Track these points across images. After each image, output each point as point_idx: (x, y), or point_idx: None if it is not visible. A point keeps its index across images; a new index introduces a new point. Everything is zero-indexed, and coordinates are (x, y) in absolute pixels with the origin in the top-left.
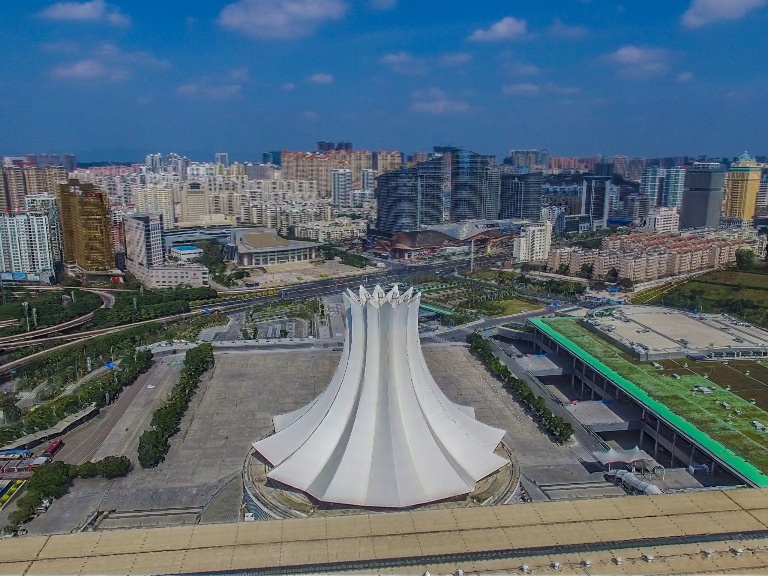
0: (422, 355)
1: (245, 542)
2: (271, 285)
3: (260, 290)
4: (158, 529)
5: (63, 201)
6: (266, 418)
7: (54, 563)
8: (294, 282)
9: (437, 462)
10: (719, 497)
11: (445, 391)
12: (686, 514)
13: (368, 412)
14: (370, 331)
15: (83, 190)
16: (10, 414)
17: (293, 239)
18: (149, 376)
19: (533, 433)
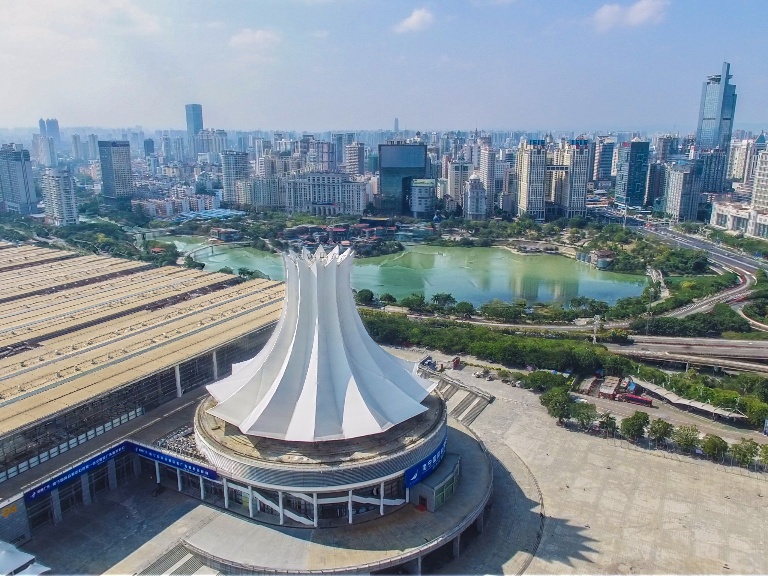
0: (298, 320)
1: None
2: None
3: None
4: None
5: None
6: (663, 505)
7: None
8: None
9: None
10: (8, 427)
11: None
12: (37, 406)
13: None
14: None
15: None
16: (754, 395)
17: None
18: None
19: None
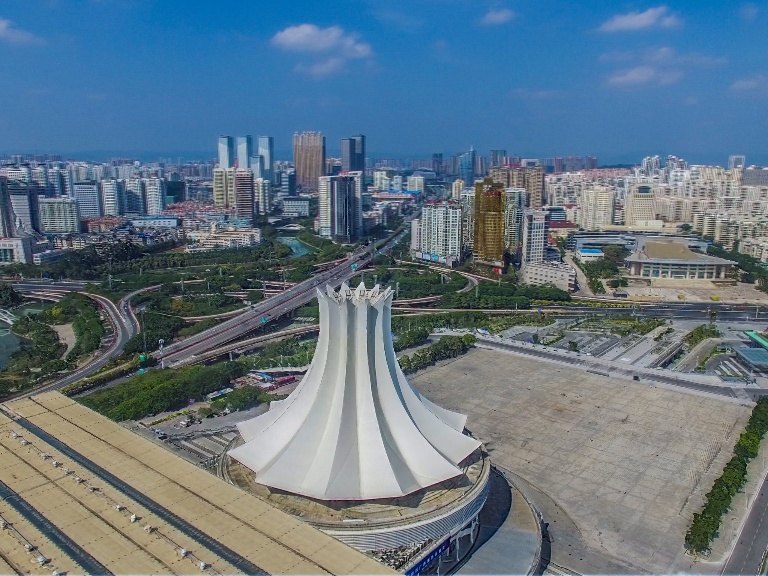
0: (385, 361)
1: (122, 448)
2: (640, 299)
3: (621, 301)
4: (110, 421)
5: (477, 197)
6: None
7: (53, 416)
8: (670, 300)
9: (326, 462)
10: None
11: (643, 446)
12: None
13: (310, 397)
14: (323, 323)
15: (491, 188)
16: None
17: (704, 253)
18: (411, 351)
19: (675, 526)
